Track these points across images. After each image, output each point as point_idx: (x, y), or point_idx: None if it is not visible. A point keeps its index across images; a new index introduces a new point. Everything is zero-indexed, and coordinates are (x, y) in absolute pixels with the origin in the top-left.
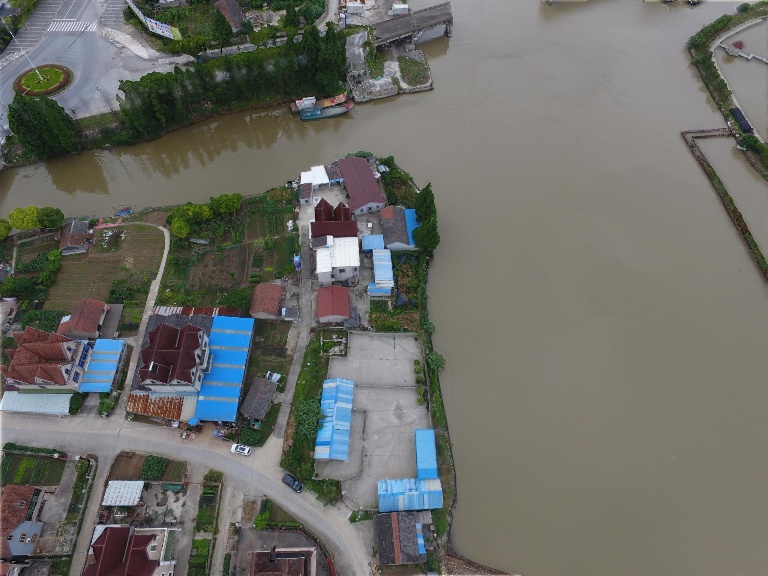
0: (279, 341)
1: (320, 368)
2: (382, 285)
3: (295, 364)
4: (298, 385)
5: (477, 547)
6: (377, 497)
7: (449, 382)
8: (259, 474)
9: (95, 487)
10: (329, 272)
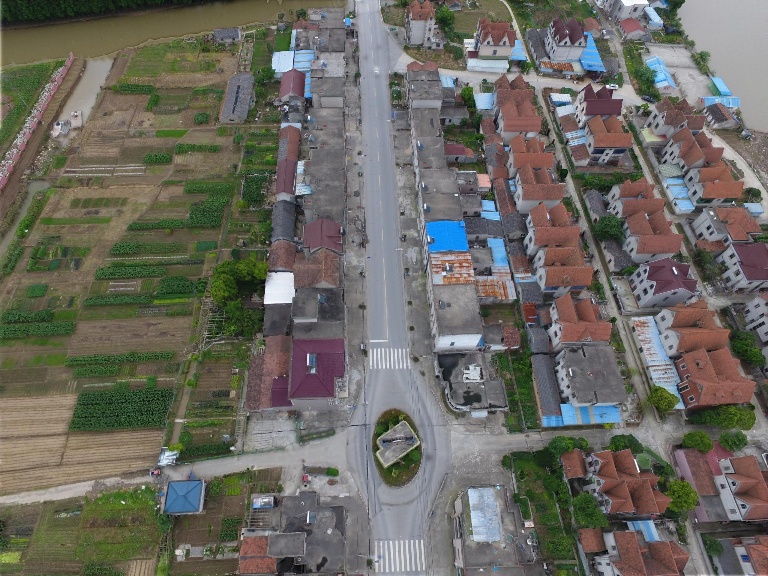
0: (606, 47)
1: (637, 58)
2: (657, 22)
3: (620, 57)
4: (627, 65)
5: (761, 129)
6: (698, 107)
7: (713, 68)
8: (627, 97)
9: (539, 100)
10: (632, 6)
